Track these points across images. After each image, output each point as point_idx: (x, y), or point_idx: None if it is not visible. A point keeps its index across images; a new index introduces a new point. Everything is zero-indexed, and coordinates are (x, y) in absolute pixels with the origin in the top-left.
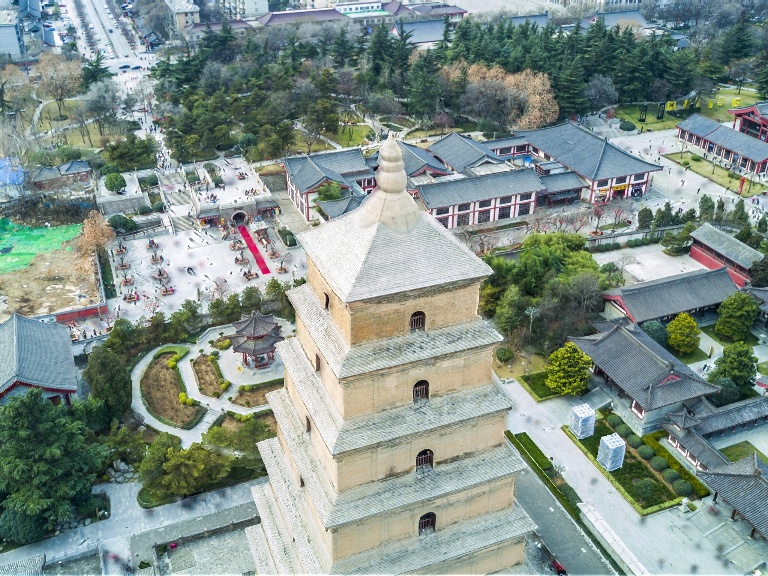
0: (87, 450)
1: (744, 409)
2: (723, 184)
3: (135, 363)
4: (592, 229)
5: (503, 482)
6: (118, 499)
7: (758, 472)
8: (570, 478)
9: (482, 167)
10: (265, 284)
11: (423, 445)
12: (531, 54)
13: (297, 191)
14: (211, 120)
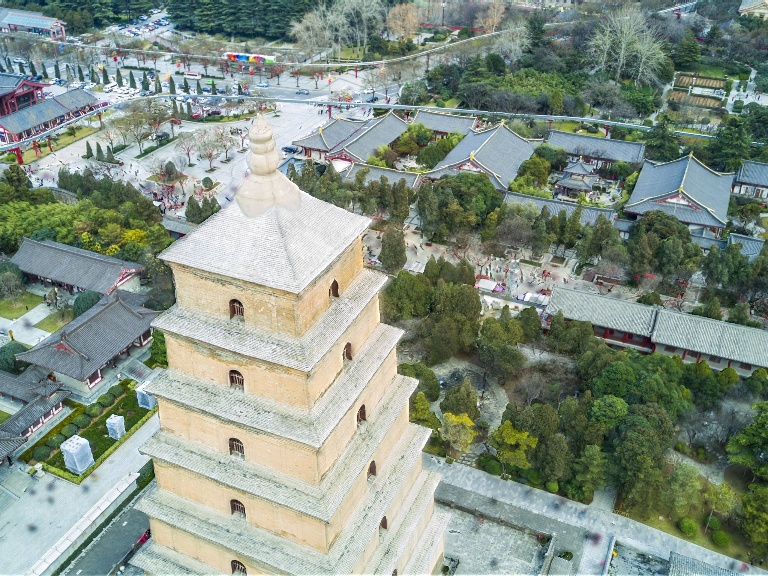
0: None
1: None
2: None
3: None
4: None
5: None
6: None
7: None
8: None
9: None
10: None
11: None
12: None
13: None
14: None
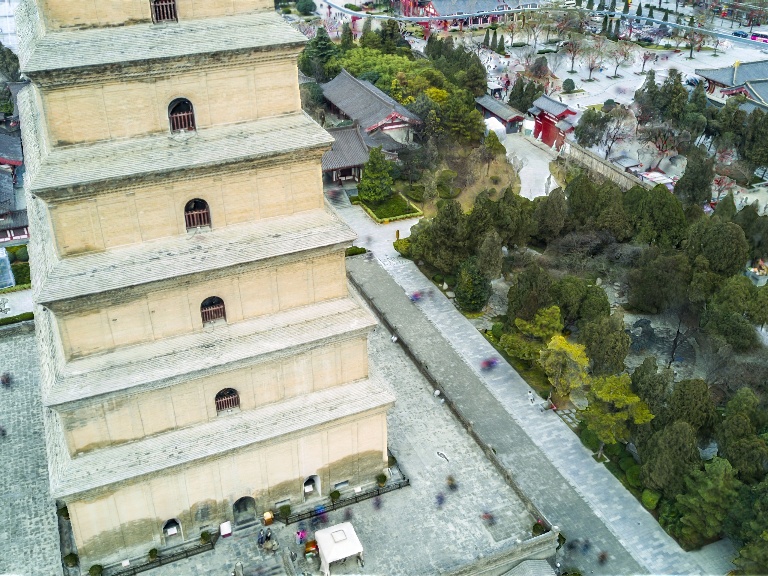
0: None
1: (1, 184)
2: None
3: None
4: None
5: None
6: None
7: None
8: (5, 314)
9: None
10: None
11: None
12: None
13: None
14: None
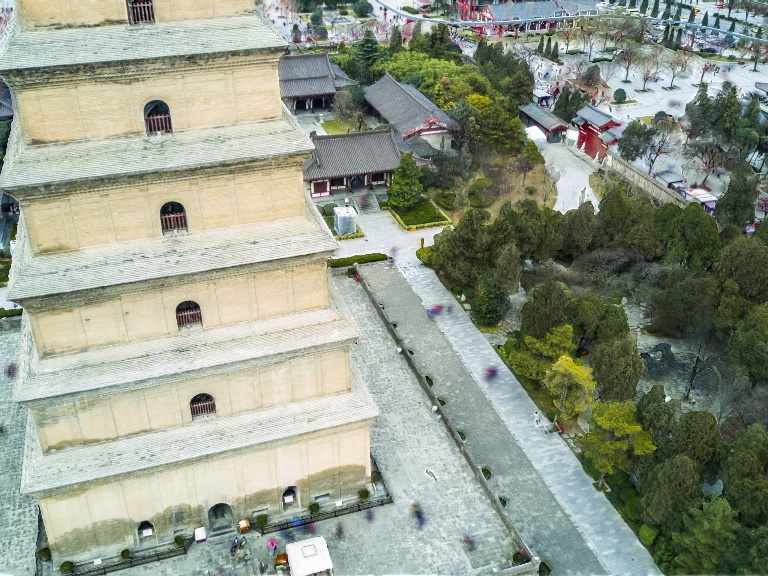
0: None
1: None
2: None
3: None
4: None
5: None
6: None
7: None
8: None
9: None
10: None
11: None
12: None
13: None
14: None
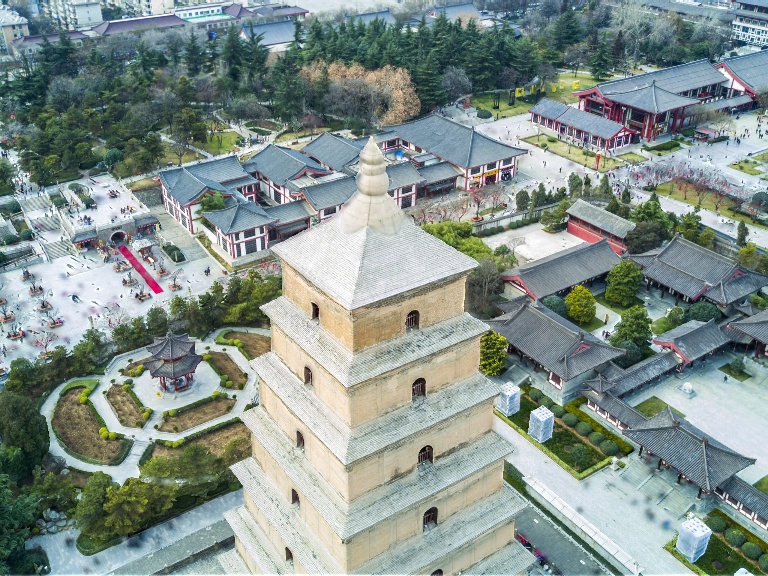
0: (13, 504)
1: (648, 367)
2: (580, 162)
3: (41, 404)
4: (473, 215)
5: (494, 467)
6: (55, 551)
7: (677, 423)
8: None
9: None
10: (169, 303)
11: (424, 442)
12: (387, 50)
13: (176, 204)
14: (69, 138)
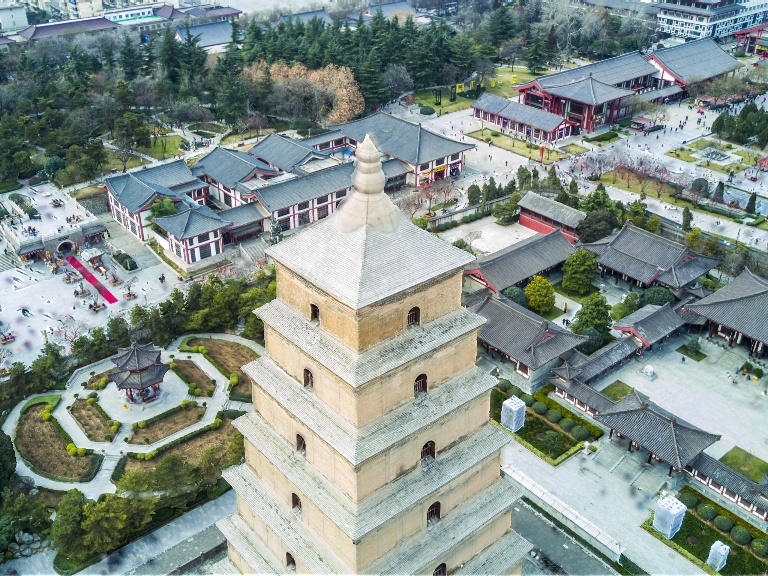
0: None
1: (611, 352)
2: (525, 155)
3: (1, 423)
4: (425, 211)
5: (492, 458)
6: (31, 574)
7: (645, 405)
8: None
9: (310, 164)
10: (128, 313)
11: (427, 438)
12: (329, 49)
13: (125, 211)
14: (6, 147)
